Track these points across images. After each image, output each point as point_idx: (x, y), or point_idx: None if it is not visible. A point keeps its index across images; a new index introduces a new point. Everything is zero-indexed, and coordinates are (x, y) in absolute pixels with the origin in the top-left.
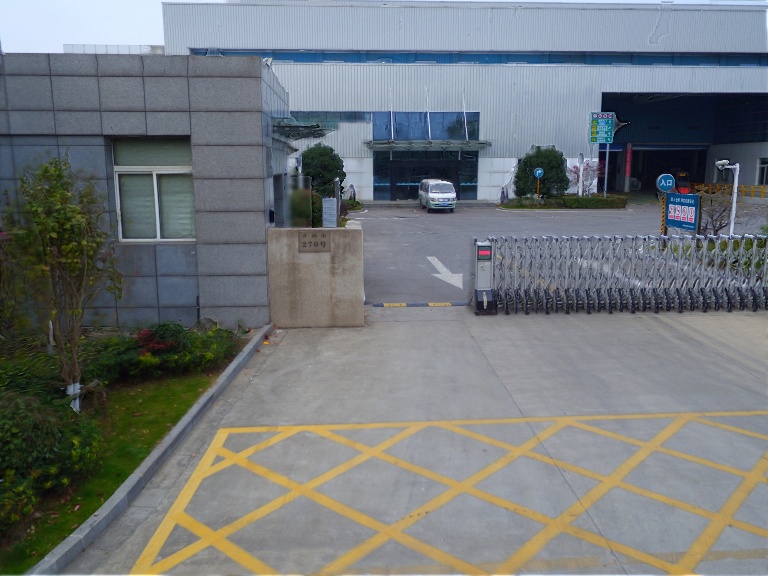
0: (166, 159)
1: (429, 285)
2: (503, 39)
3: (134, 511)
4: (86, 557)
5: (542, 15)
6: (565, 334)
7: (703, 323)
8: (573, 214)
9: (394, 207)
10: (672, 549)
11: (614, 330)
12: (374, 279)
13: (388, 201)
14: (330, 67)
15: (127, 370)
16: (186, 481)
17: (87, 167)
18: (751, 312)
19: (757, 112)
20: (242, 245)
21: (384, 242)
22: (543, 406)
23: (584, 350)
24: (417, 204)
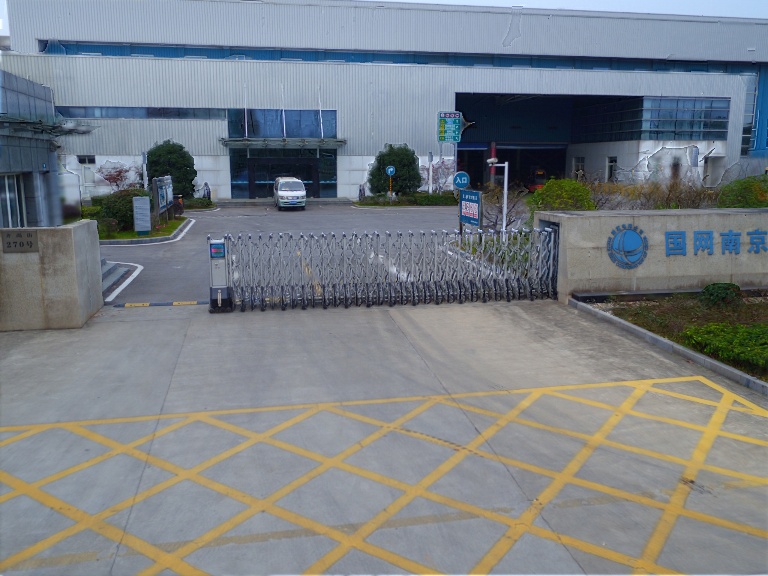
0: None
1: (197, 284)
2: (367, 38)
3: None
4: None
5: (405, 16)
6: (282, 330)
7: (426, 315)
8: (420, 211)
9: (249, 205)
10: (182, 538)
11: (334, 324)
12: (146, 279)
13: (247, 199)
14: (181, 62)
15: None
16: None
17: None
18: (481, 303)
19: (605, 113)
20: None
21: (200, 241)
22: (190, 402)
23: (285, 345)
24: (273, 202)
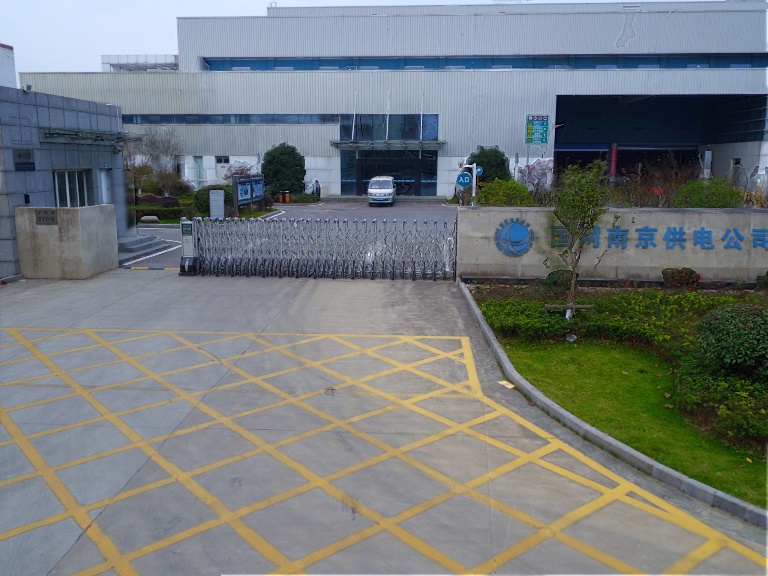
0: None
1: None
2: (486, 44)
3: None
4: None
5: (524, 20)
6: (211, 288)
7: None
8: None
9: (350, 201)
10: None
11: (253, 287)
12: (174, 252)
13: (354, 196)
14: (302, 74)
15: None
16: None
17: None
18: (390, 280)
19: (732, 113)
20: None
21: None
22: None
23: (199, 297)
24: None
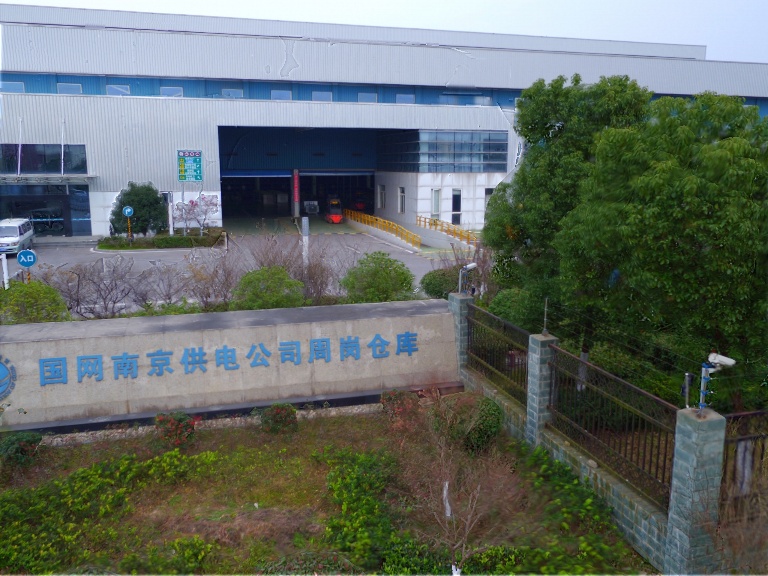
0: None
1: None
2: (149, 64)
3: None
4: None
5: (189, 41)
6: None
7: None
8: (146, 256)
9: None
10: None
11: None
12: None
13: None
14: None
15: None
16: None
17: None
18: None
19: (396, 143)
20: None
21: None
22: None
23: None
24: None
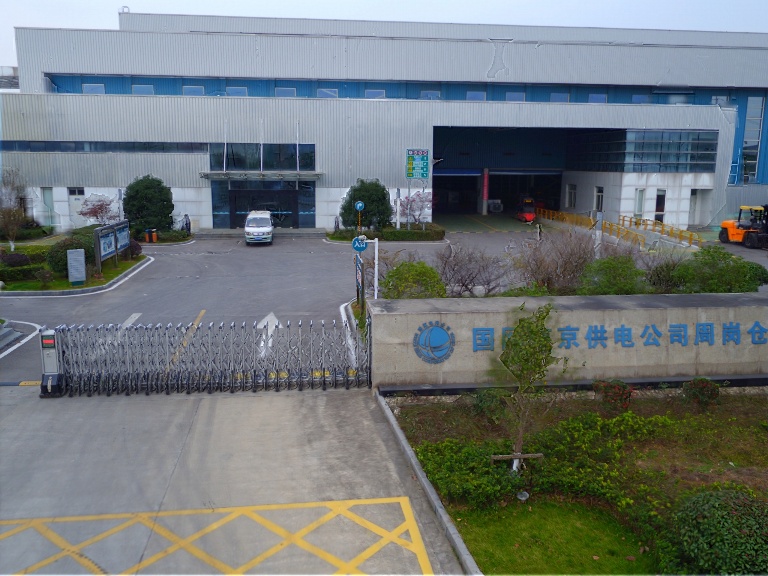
0: None
1: None
2: (358, 68)
3: None
4: None
5: (396, 46)
6: (84, 422)
7: (231, 406)
8: None
9: (224, 237)
10: None
11: (137, 416)
12: (28, 347)
13: (227, 229)
14: (165, 99)
15: None
16: None
17: None
18: (297, 391)
19: (594, 143)
20: None
21: (130, 291)
22: None
23: (70, 442)
24: None
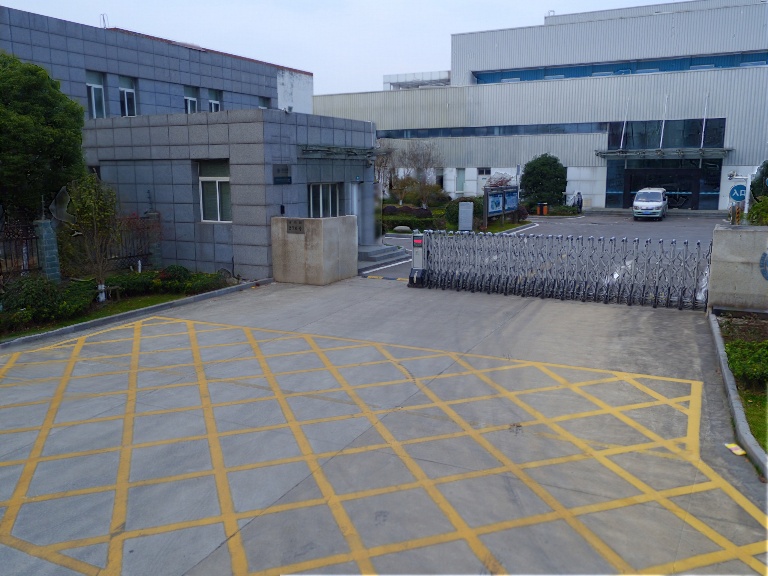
0: (223, 173)
1: None
2: None
3: (73, 334)
4: (36, 341)
5: None
6: (433, 302)
7: (557, 307)
8: None
9: (614, 214)
10: None
11: (475, 304)
12: None
13: (620, 209)
14: (570, 82)
15: (148, 287)
16: (106, 329)
17: (184, 177)
18: (626, 306)
19: None
20: (254, 226)
21: None
22: (313, 329)
23: None
24: None
